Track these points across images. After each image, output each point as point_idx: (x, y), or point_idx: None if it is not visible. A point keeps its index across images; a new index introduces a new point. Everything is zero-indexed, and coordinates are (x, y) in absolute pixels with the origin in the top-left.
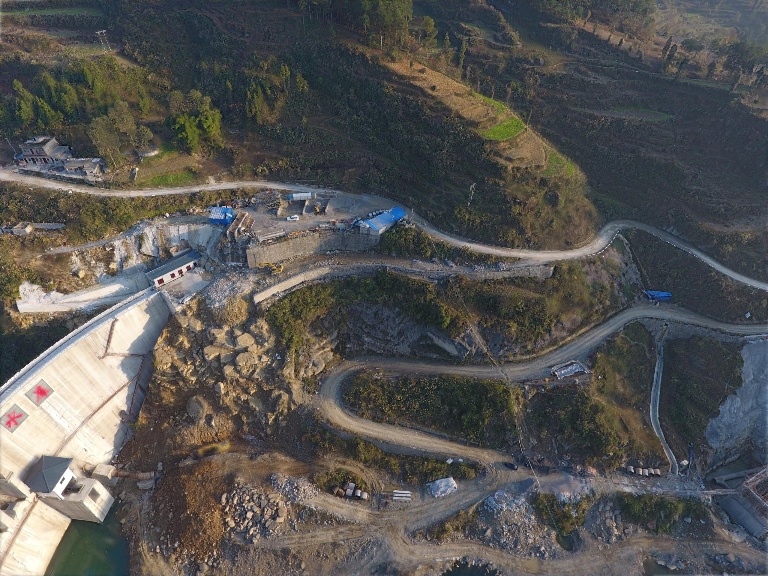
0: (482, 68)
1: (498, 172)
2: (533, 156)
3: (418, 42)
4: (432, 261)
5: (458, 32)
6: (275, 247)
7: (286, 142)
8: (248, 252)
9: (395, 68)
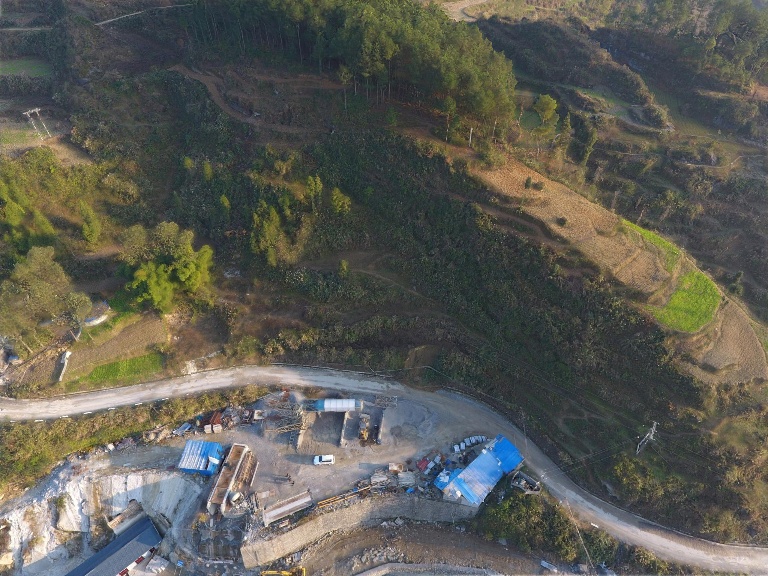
0: (617, 166)
1: (693, 395)
2: (746, 356)
3: (515, 122)
4: (578, 571)
5: (573, 104)
6: (292, 533)
7: (313, 297)
8: (243, 549)
9: (494, 182)
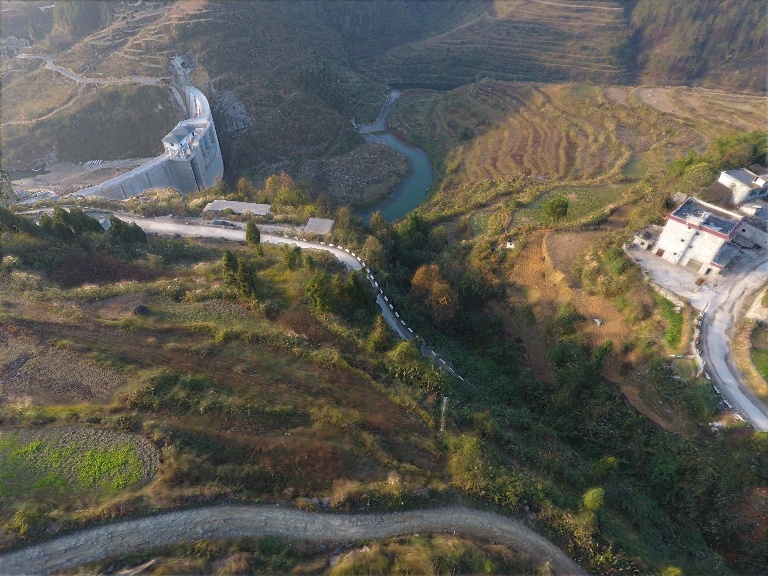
0: None
1: None
2: None
3: None
4: None
5: None
6: None
7: None
8: None
9: None
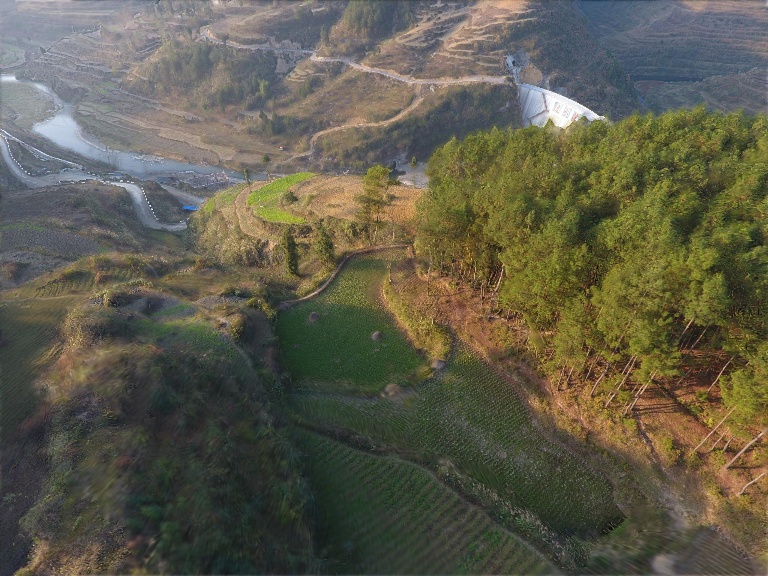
0: None
1: None
2: None
3: (392, 291)
4: None
5: (258, 324)
6: None
7: None
8: None
9: None
